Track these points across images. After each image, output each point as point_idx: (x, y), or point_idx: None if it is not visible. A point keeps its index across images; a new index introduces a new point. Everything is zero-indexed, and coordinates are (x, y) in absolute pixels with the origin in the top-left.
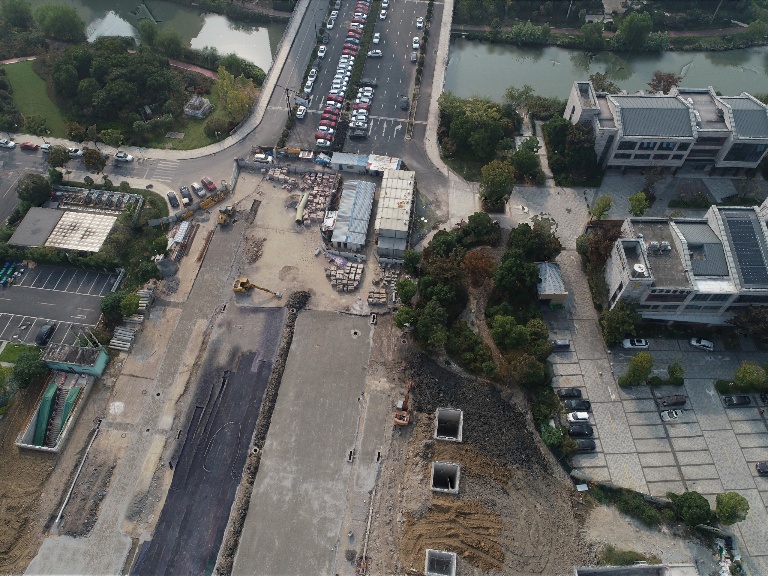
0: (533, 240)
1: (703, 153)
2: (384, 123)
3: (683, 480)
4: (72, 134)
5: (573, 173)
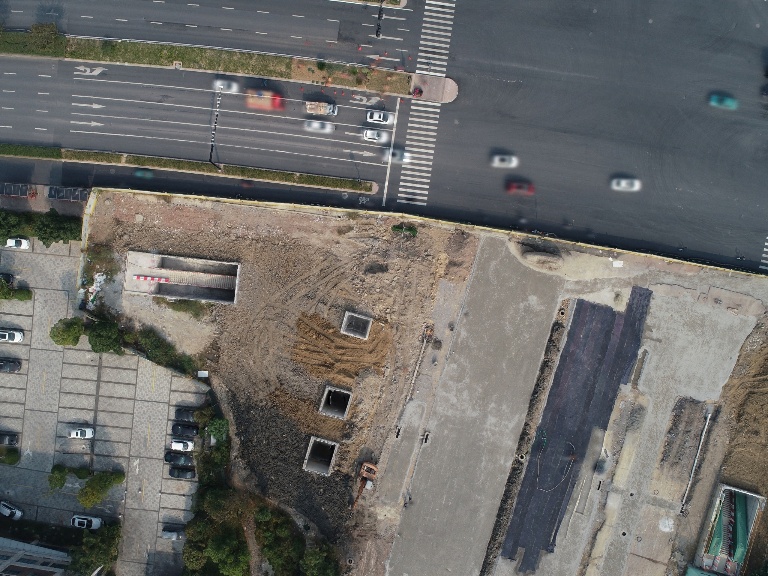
0: None
1: None
2: None
3: (100, 367)
4: None
5: None
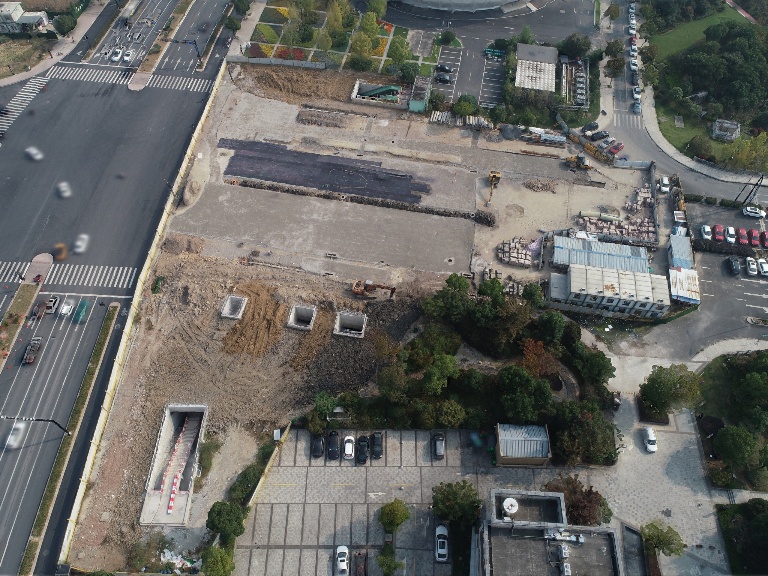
0: (567, 410)
1: None
2: None
3: (268, 547)
4: (643, 50)
5: None
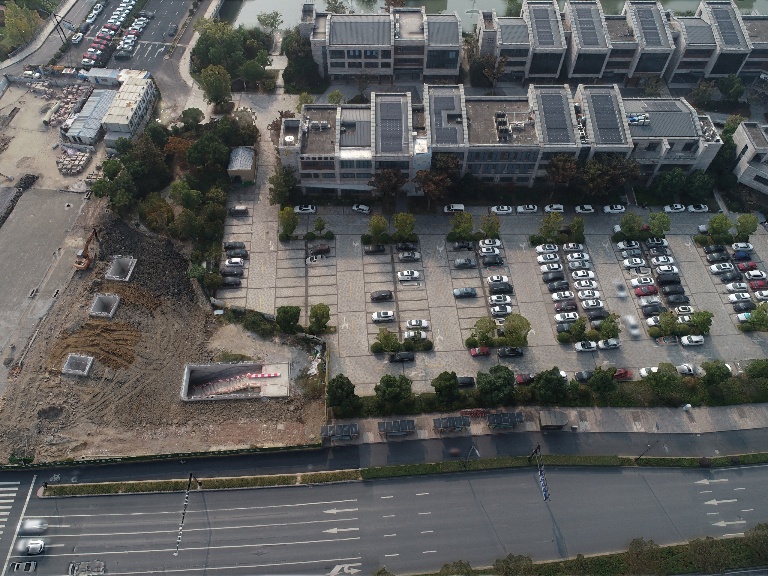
0: (225, 126)
1: (411, 62)
2: (149, 46)
3: (306, 306)
4: None
5: (301, 82)
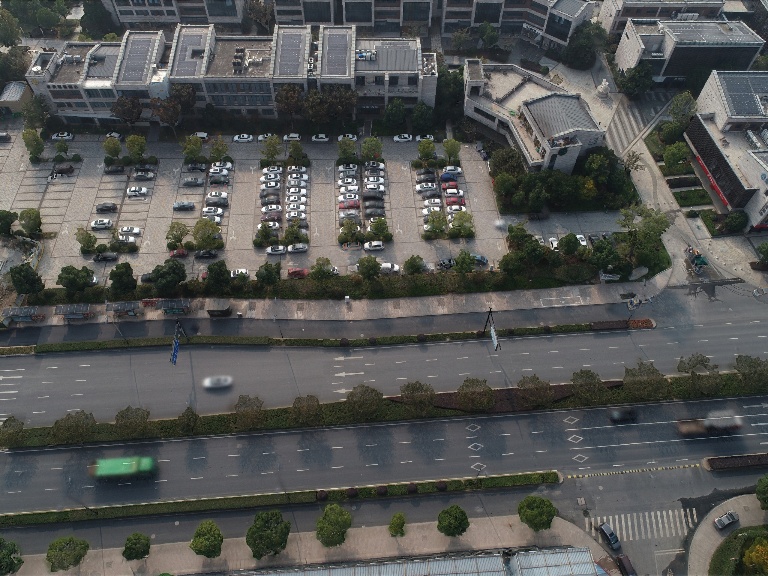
0: None
1: (197, 11)
2: None
3: None
4: None
5: (97, 30)
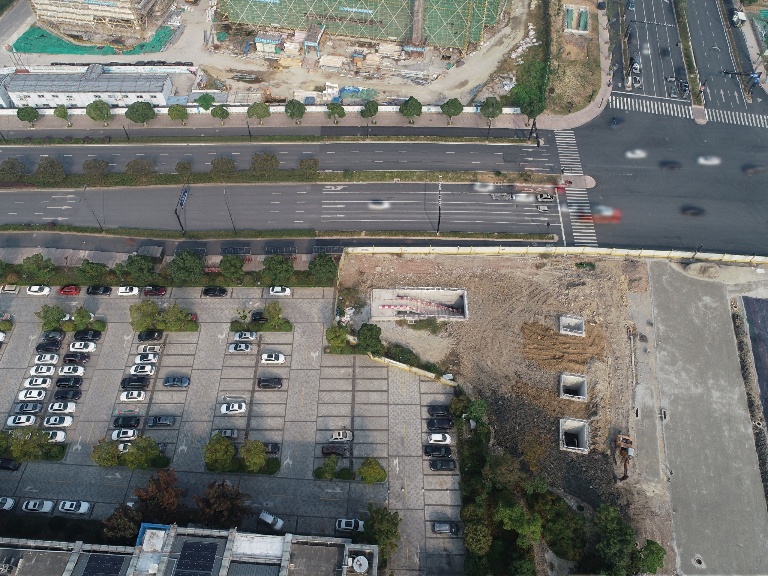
0: None
1: None
2: None
3: (354, 379)
4: None
5: None
